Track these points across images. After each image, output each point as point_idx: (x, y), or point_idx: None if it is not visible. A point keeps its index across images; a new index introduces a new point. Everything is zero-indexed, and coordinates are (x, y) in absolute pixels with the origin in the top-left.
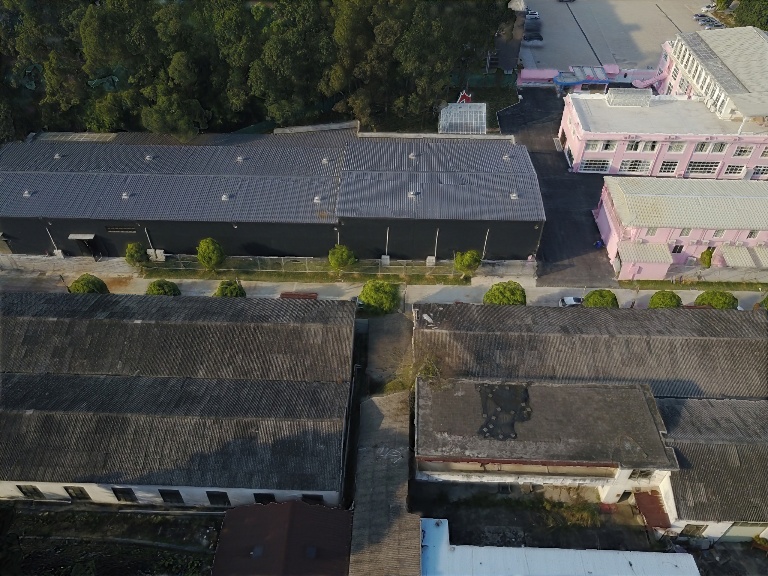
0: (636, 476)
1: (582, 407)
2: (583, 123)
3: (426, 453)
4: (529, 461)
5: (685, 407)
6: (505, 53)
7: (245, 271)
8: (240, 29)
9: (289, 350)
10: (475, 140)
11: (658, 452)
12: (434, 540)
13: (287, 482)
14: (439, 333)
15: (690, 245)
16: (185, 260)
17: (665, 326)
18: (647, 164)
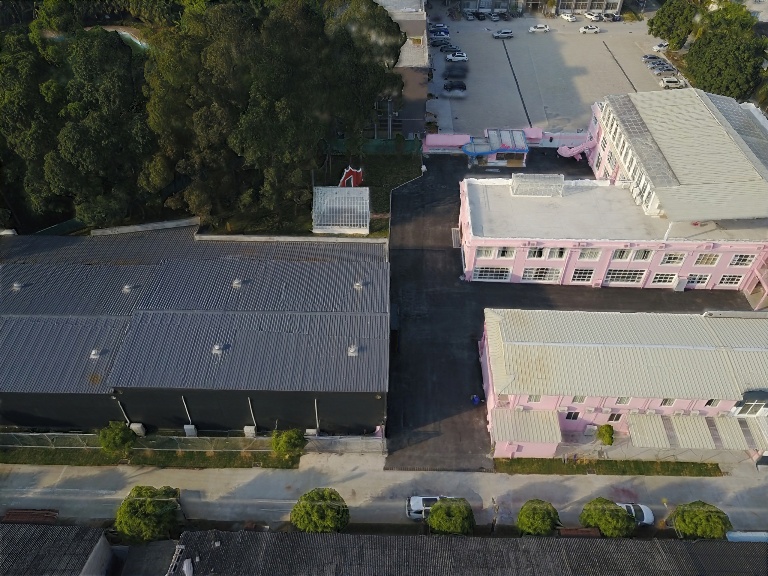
0: None
1: None
2: (476, 222)
3: None
4: None
5: None
6: (409, 114)
7: (3, 447)
8: (28, 113)
9: None
10: (340, 244)
11: None
12: None
13: None
14: None
15: (587, 412)
16: None
17: None
18: (556, 272)
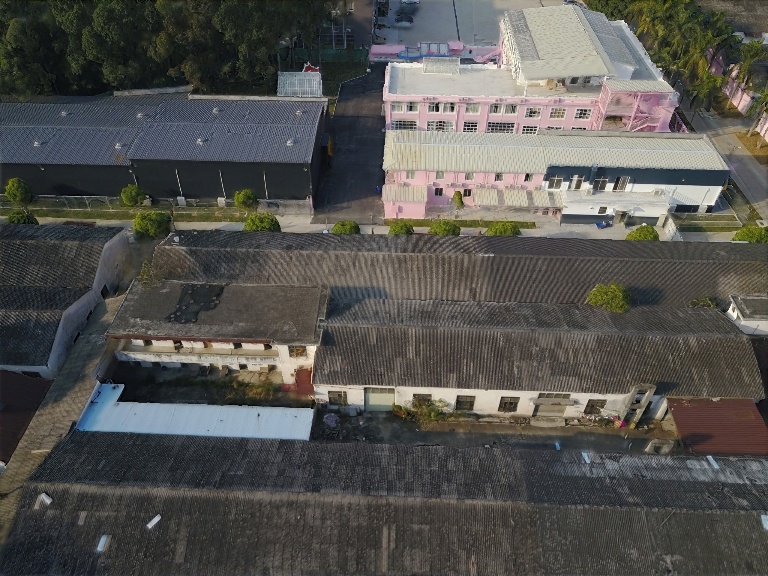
0: (294, 354)
1: (263, 300)
2: (392, 87)
3: (115, 332)
4: (198, 338)
5: (359, 304)
6: (359, 30)
7: (55, 210)
8: None
9: (45, 262)
10: None
11: (309, 332)
12: (105, 398)
13: (4, 359)
14: (177, 249)
15: (447, 187)
16: (5, 201)
17: (379, 246)
18: (451, 125)
